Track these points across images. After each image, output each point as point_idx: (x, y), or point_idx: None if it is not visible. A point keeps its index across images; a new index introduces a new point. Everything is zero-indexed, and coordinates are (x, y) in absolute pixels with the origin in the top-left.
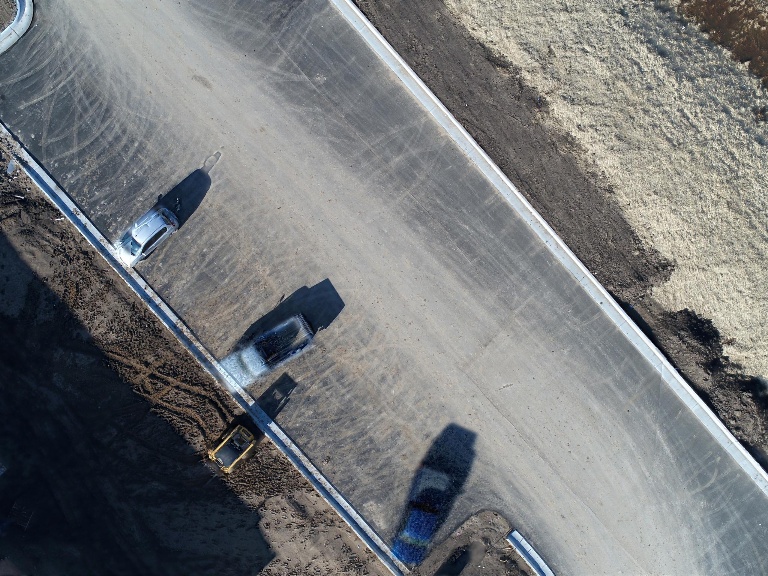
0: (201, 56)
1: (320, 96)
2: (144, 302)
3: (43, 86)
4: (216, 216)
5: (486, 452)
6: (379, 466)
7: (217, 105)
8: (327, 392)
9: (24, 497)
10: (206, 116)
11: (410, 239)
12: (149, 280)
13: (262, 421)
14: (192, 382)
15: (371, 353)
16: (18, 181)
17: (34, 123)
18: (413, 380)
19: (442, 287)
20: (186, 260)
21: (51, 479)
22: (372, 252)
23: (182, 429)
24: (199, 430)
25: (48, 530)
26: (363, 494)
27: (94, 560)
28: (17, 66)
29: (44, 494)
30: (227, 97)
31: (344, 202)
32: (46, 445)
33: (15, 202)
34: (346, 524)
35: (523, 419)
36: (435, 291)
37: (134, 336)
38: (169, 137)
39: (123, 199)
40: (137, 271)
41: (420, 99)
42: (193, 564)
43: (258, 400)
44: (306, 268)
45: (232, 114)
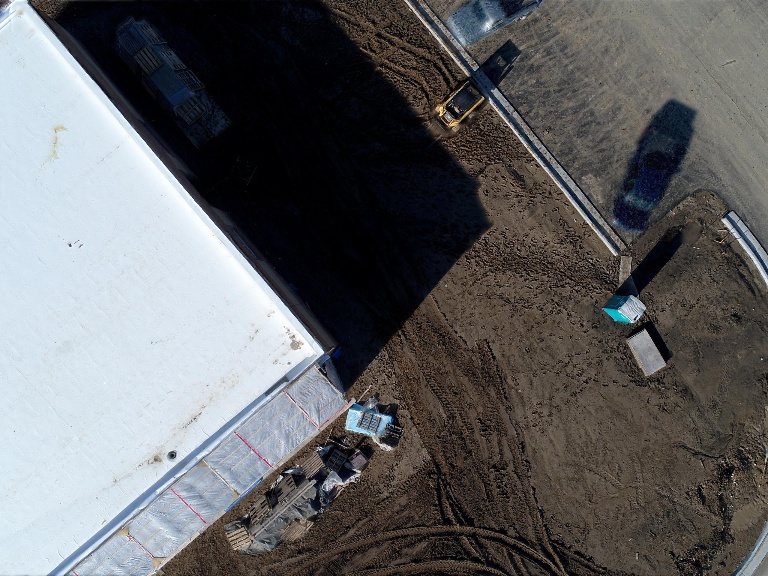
0: None
1: None
2: None
3: None
4: None
5: (706, 129)
6: (599, 139)
7: None
8: (550, 62)
9: (248, 151)
10: None
11: None
12: None
13: (486, 87)
14: (418, 44)
15: (596, 24)
16: None
17: None
18: (637, 53)
19: None
20: None
21: (275, 134)
22: None
23: (406, 91)
24: (423, 93)
25: (270, 186)
26: (582, 166)
27: (314, 219)
28: None
29: (268, 149)
30: None
31: None
32: (271, 100)
33: None
34: (564, 196)
35: (745, 97)
36: None
37: None
38: None
39: None
40: None
41: None
42: (412, 228)
43: (482, 66)
44: None
45: None
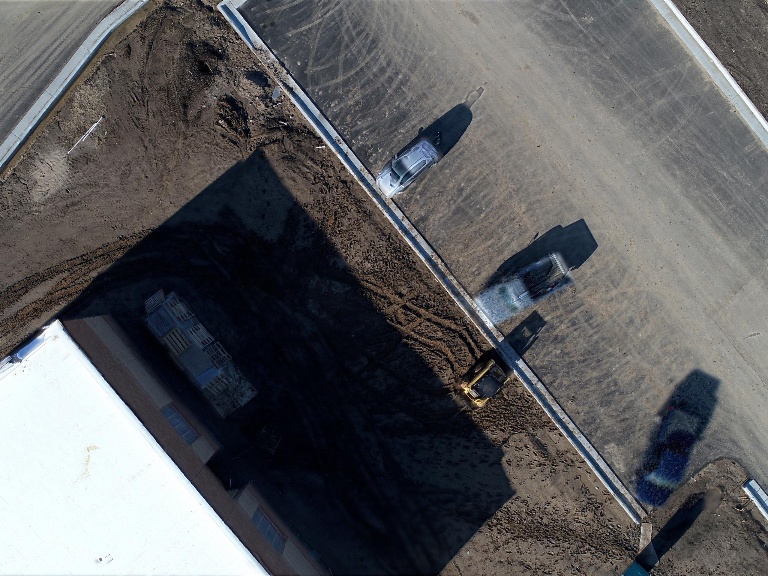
0: None
1: (586, 36)
2: (402, 233)
3: (311, 14)
4: (475, 151)
5: (729, 400)
6: (622, 408)
7: (483, 41)
8: (575, 332)
9: (274, 421)
10: (471, 51)
11: (667, 183)
12: (406, 212)
13: (510, 358)
14: (444, 315)
15: (621, 295)
16: (282, 107)
17: (301, 50)
18: (661, 324)
19: (696, 232)
20: (443, 194)
21: (301, 405)
22: (628, 194)
23: (432, 362)
24: (448, 363)
25: (295, 455)
26: (605, 436)
27: (338, 488)
28: None
29: (294, 419)
30: (493, 33)
31: (604, 143)
32: (298, 371)
33: (279, 128)
34: (587, 465)
35: (767, 368)
36: (688, 236)
37: (389, 267)
38: (433, 70)
39: (384, 130)
40: (395, 202)
41: (686, 43)
42: (435, 497)
43: (507, 336)
44: (562, 207)
45: (497, 50)
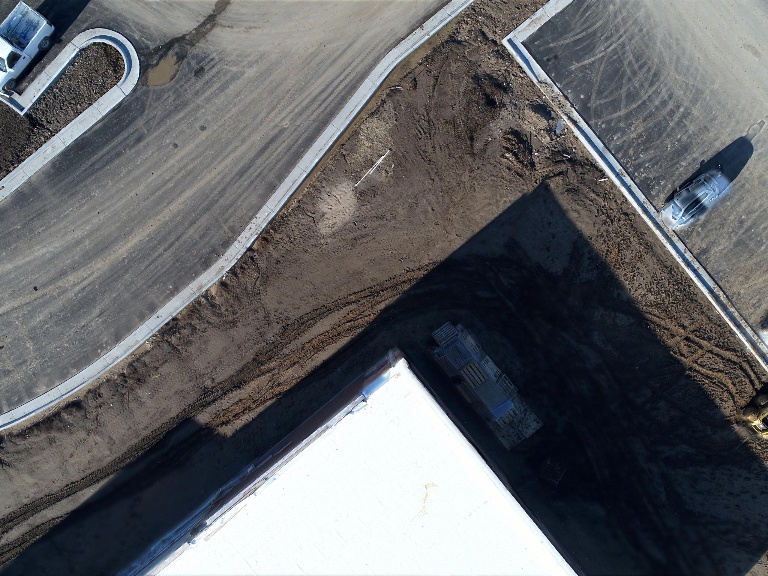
0: (752, 25)
1: None
2: (685, 265)
3: (594, 48)
4: (756, 184)
5: None
6: None
7: (764, 74)
8: None
9: (558, 453)
10: (752, 85)
11: None
12: (688, 244)
13: None
14: (725, 347)
15: None
16: (565, 140)
17: (584, 84)
18: None
19: None
20: (725, 226)
21: (585, 437)
22: None
23: (713, 393)
24: (730, 395)
25: (579, 487)
26: None
27: (621, 520)
28: (570, 27)
29: (578, 451)
30: None
31: None
32: (582, 403)
33: (563, 161)
34: None
35: None
36: None
37: (671, 299)
38: (714, 104)
39: (666, 163)
40: (677, 235)
41: None
42: (716, 528)
43: None
44: None
45: None
